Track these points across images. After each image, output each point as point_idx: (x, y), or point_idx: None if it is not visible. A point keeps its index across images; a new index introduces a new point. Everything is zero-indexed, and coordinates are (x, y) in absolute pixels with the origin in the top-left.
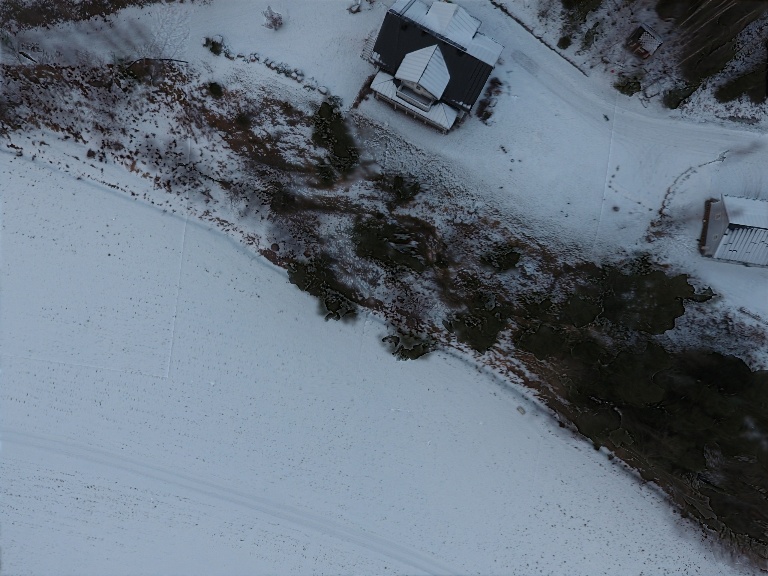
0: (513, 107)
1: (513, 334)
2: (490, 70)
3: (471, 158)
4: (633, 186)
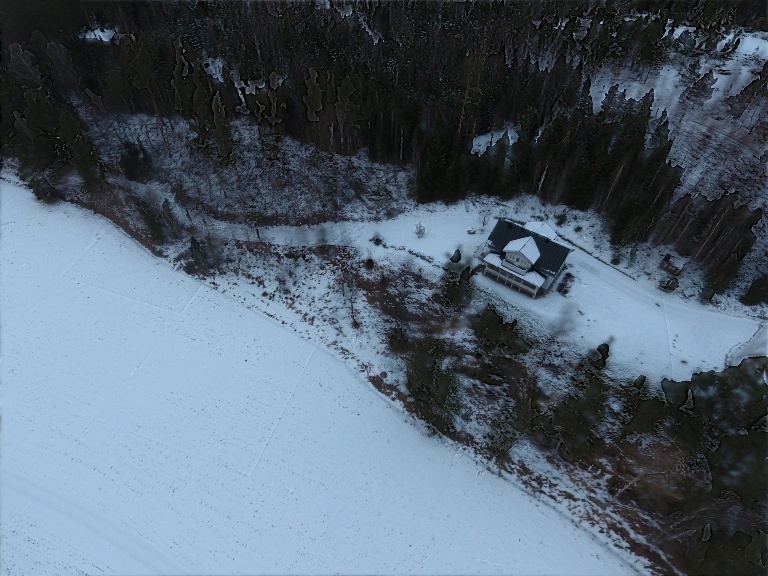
0: (584, 290)
1: (609, 482)
2: (568, 251)
3: (555, 315)
4: (694, 349)
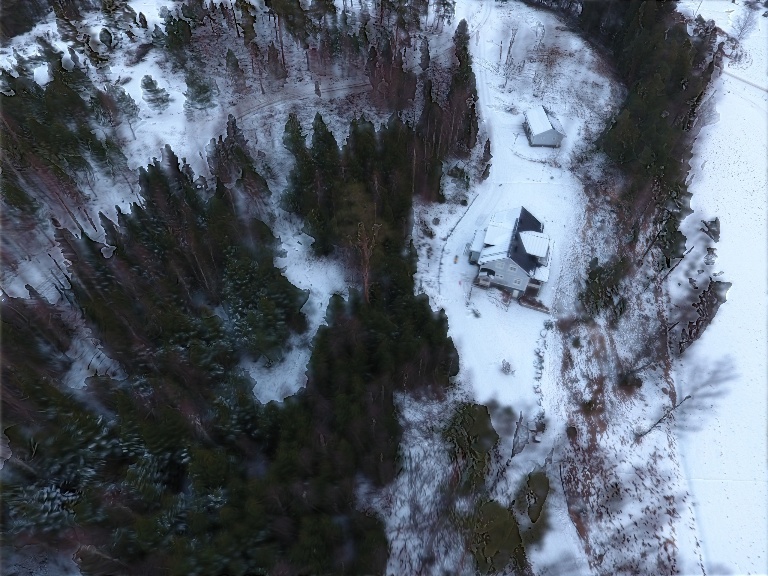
0: None
1: None
2: None
3: None
4: (535, 173)
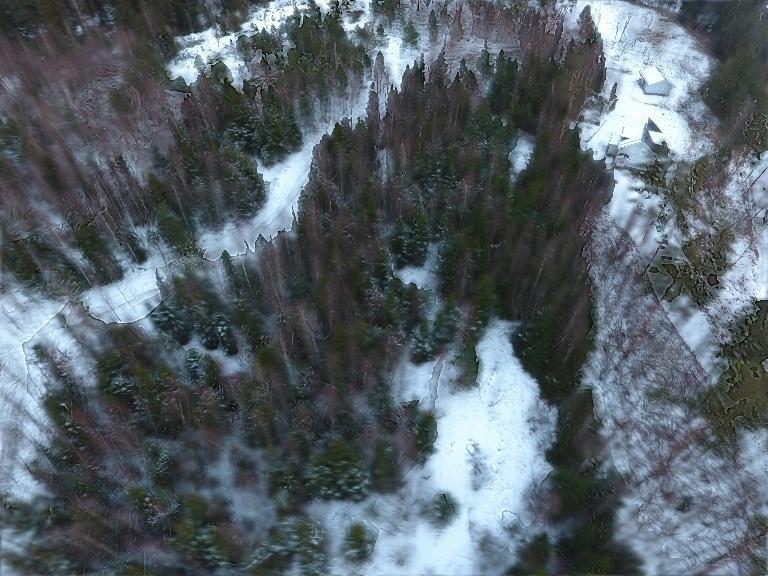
0: None
1: None
2: None
3: None
4: (649, 111)
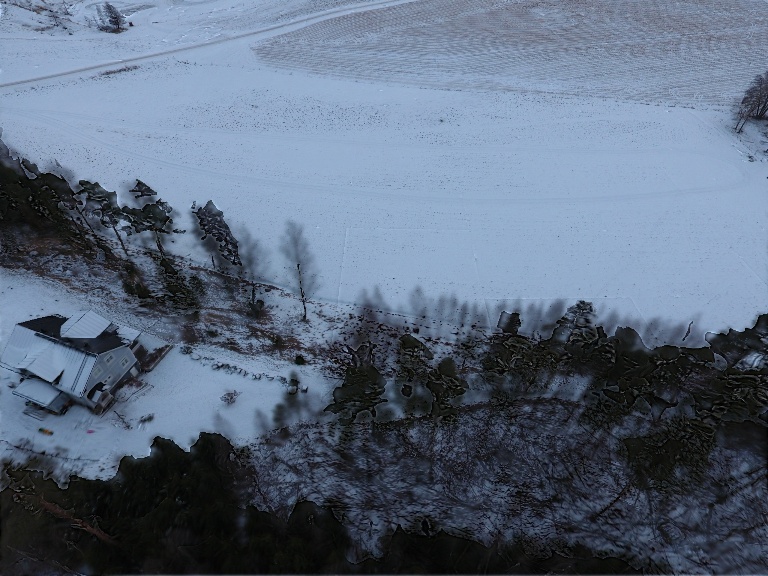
0: None
1: None
2: None
3: None
4: None
